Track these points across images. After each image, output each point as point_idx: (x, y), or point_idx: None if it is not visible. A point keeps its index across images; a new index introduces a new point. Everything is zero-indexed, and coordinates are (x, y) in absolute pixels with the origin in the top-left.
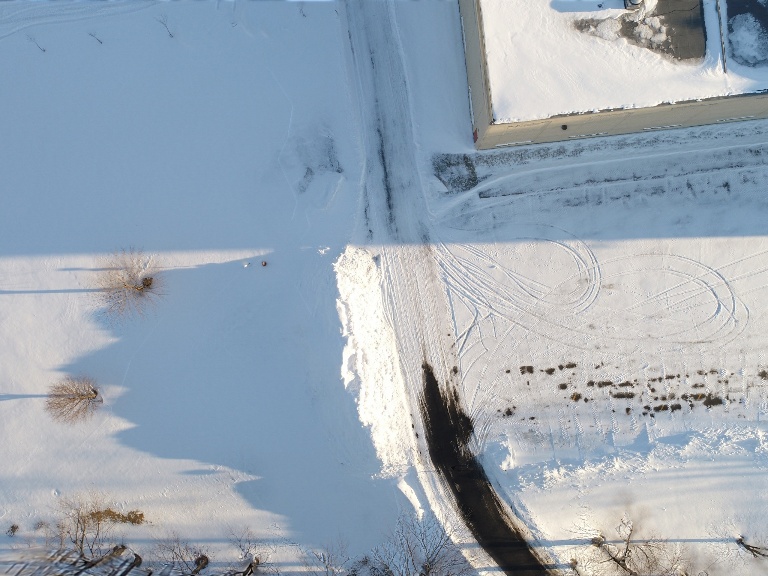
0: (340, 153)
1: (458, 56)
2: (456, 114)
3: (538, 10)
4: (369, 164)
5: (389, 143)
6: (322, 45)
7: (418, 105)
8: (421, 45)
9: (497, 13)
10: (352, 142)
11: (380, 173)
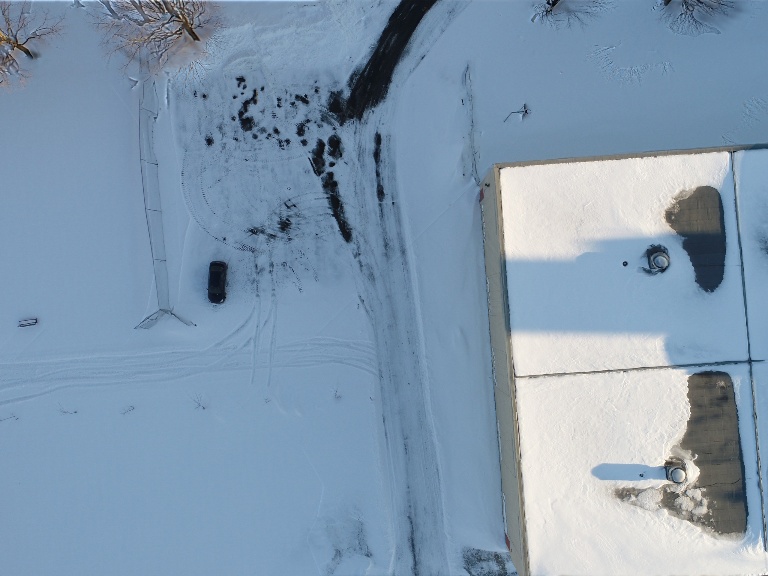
0: (369, 537)
1: (492, 454)
2: (488, 513)
3: (579, 477)
4: (398, 551)
5: (419, 531)
6: (356, 428)
7: (450, 496)
8: (455, 437)
9: (538, 479)
10: (382, 528)
11: (409, 561)
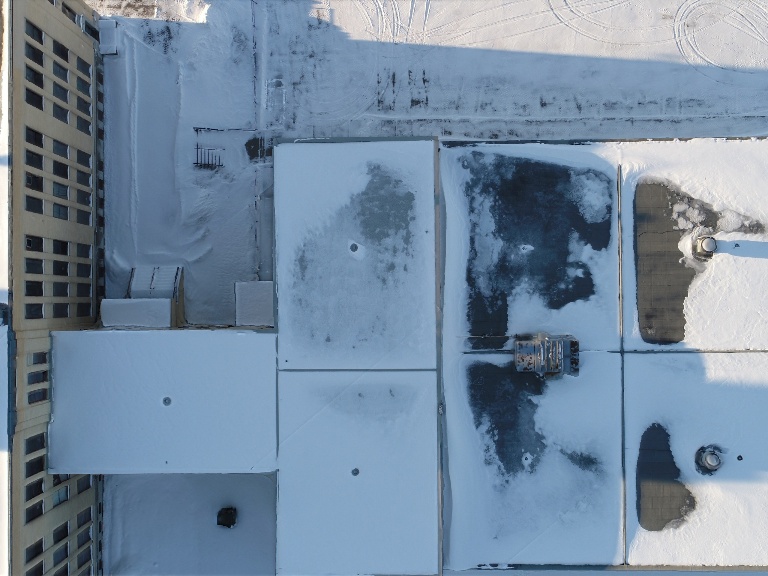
0: None
1: None
2: None
3: None
4: None
5: None
6: None
7: None
8: None
9: None
10: None
11: None
